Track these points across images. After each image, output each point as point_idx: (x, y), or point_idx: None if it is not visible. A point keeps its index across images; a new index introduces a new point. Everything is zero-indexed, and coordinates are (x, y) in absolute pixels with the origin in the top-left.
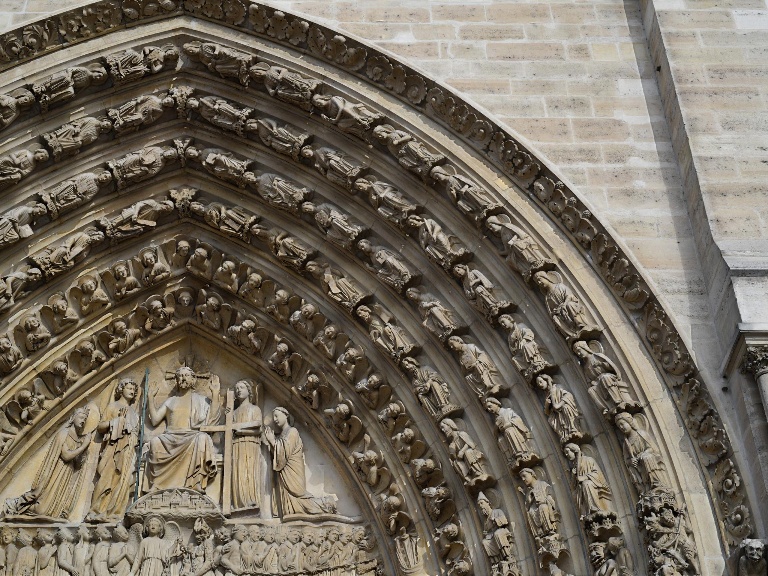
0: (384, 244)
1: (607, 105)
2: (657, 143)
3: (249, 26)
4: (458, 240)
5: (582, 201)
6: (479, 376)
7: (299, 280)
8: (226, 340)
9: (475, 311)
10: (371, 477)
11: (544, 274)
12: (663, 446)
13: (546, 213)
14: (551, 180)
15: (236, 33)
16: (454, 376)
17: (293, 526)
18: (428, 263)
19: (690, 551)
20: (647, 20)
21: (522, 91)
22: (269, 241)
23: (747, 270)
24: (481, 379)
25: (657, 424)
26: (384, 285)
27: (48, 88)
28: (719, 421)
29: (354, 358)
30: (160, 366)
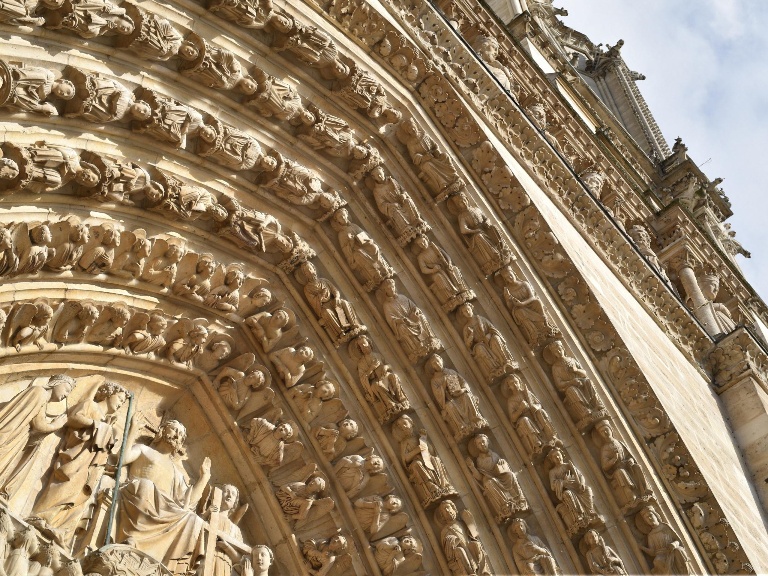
0: (498, 454)
1: None
2: None
3: (466, 155)
4: None
5: None
6: None
7: (372, 425)
8: (236, 428)
9: None
10: None
11: None
12: None
13: (694, 539)
14: None
15: (452, 151)
16: None
17: None
18: (543, 506)
19: None
20: (748, 432)
21: None
22: (370, 362)
23: None
24: None
25: None
26: (479, 495)
27: (308, 33)
28: None
29: (412, 550)
30: (138, 399)
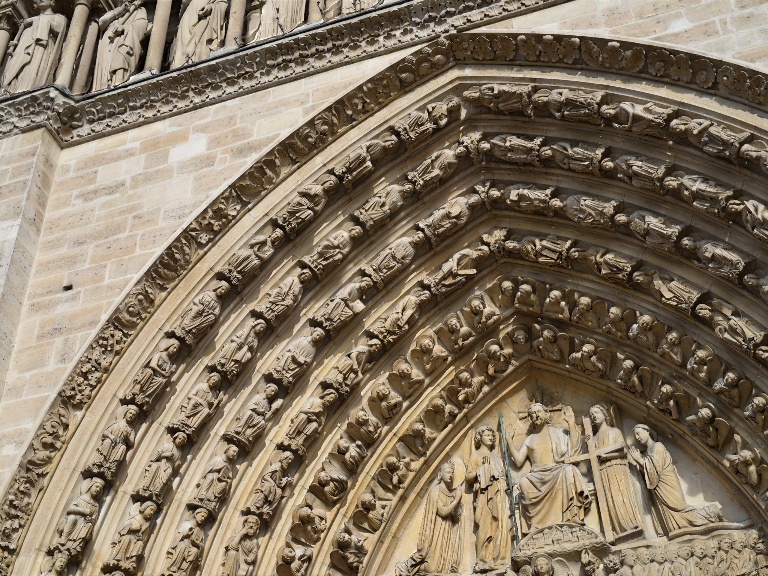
0: (708, 237)
1: None
2: None
3: (521, 58)
4: None
5: None
6: None
7: (629, 293)
8: (570, 369)
9: None
10: (751, 477)
11: None
12: None
13: None
14: None
15: (510, 68)
16: None
17: (681, 542)
18: (759, 246)
19: None
20: None
21: None
22: (590, 262)
23: None
24: None
25: None
26: (718, 279)
27: (348, 168)
28: None
29: (704, 359)
30: (511, 408)
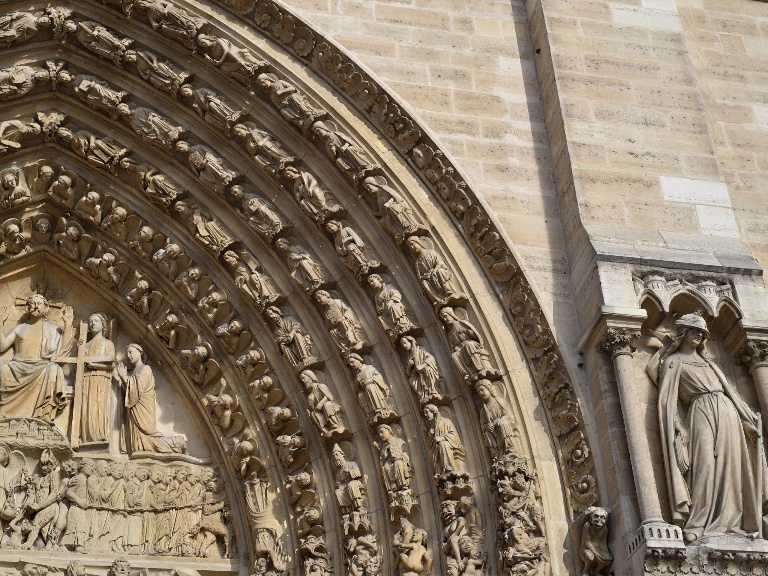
0: (257, 192)
1: (487, 80)
2: (532, 123)
3: None
4: (333, 196)
5: (459, 172)
6: (344, 331)
7: (165, 218)
8: (83, 271)
9: (344, 267)
10: (224, 421)
11: (417, 239)
12: (519, 414)
13: (422, 179)
14: (431, 148)
15: None
16: (317, 329)
17: (142, 463)
18: (300, 215)
19: (538, 514)
20: (530, 2)
21: (408, 56)
22: (138, 176)
23: (612, 256)
24: (346, 335)
25: (514, 393)
26: (253, 232)
27: None
28: (573, 395)
29: (217, 302)
30: (10, 291)
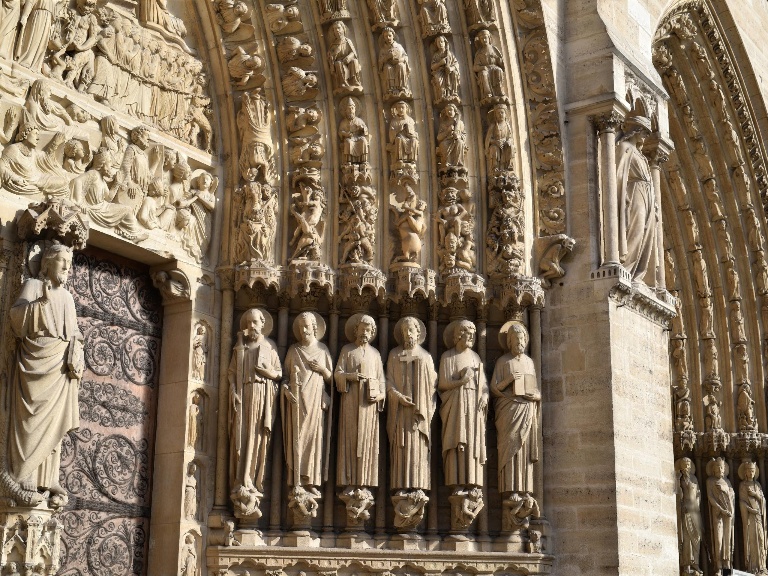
0: None
1: None
2: None
3: None
4: None
5: None
6: (389, 5)
7: None
8: None
9: None
10: (234, 26)
11: None
12: (517, 141)
13: None
14: None
15: None
16: None
17: (153, 35)
18: None
19: None
20: None
21: None
22: None
23: (621, 53)
24: (390, 8)
25: (517, 123)
26: None
27: None
28: (559, 143)
29: None
30: None
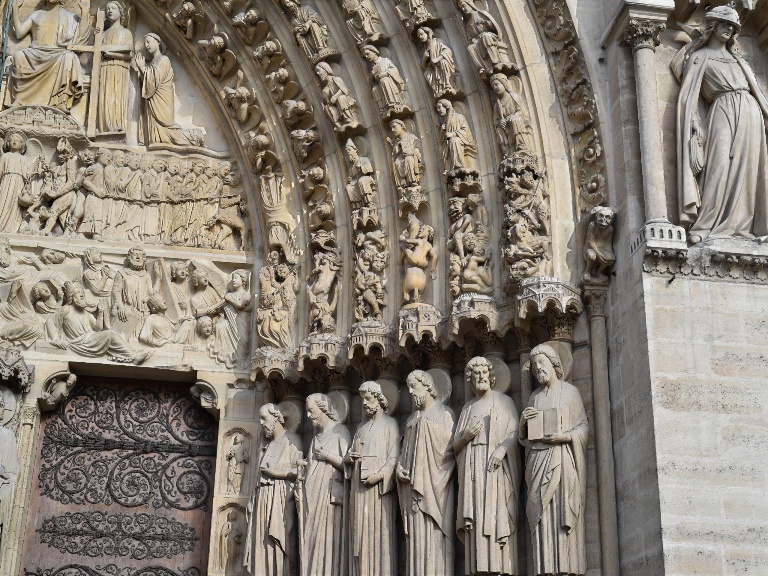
0: None
1: None
2: None
3: None
4: None
5: None
6: (360, 22)
7: None
8: None
9: None
10: (241, 114)
11: None
12: (533, 110)
13: None
14: None
15: None
16: (335, 19)
17: (159, 155)
18: None
19: (544, 213)
20: None
21: None
22: None
23: None
24: (362, 25)
25: (530, 88)
26: None
27: None
28: (591, 91)
29: None
30: None
